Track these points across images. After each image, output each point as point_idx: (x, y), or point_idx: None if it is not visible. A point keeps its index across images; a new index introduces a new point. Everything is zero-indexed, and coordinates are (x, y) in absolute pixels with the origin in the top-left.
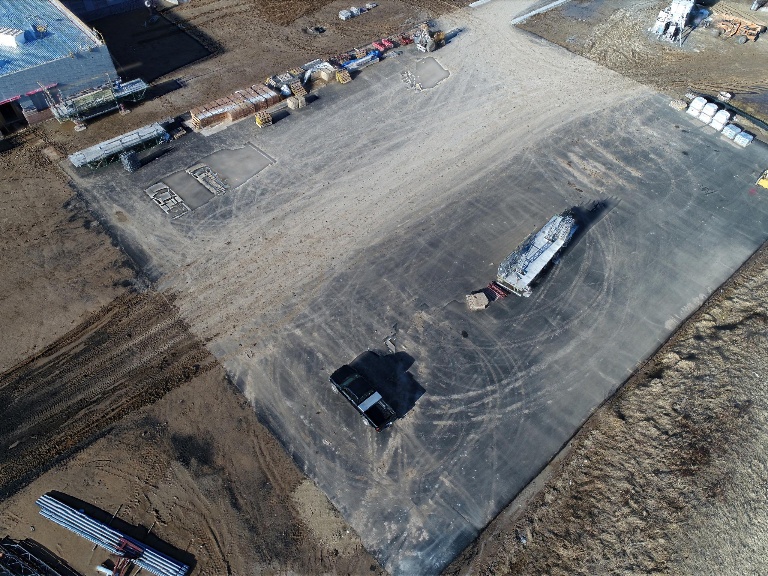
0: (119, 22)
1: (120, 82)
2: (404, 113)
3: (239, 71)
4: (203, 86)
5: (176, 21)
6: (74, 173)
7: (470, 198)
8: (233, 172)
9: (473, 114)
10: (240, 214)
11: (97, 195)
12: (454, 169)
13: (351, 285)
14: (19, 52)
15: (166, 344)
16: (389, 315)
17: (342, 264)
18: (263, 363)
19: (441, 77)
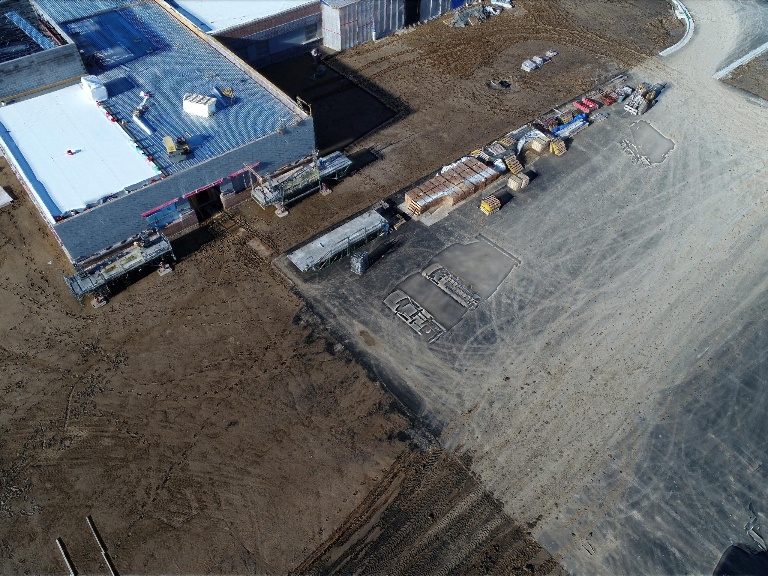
0: (283, 73)
1: (317, 155)
2: (643, 196)
3: (435, 137)
4: (402, 157)
5: (344, 72)
6: (294, 276)
7: (767, 317)
8: (477, 276)
9: (723, 199)
10: (506, 337)
11: (330, 307)
12: (732, 275)
13: (675, 444)
14: (214, 124)
15: (482, 531)
16: (737, 490)
17: (653, 412)
18: (611, 563)
19: (666, 148)
